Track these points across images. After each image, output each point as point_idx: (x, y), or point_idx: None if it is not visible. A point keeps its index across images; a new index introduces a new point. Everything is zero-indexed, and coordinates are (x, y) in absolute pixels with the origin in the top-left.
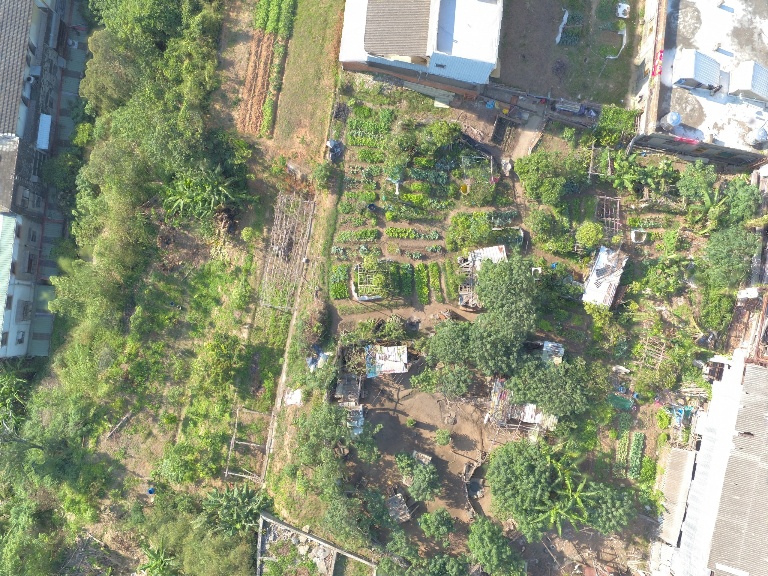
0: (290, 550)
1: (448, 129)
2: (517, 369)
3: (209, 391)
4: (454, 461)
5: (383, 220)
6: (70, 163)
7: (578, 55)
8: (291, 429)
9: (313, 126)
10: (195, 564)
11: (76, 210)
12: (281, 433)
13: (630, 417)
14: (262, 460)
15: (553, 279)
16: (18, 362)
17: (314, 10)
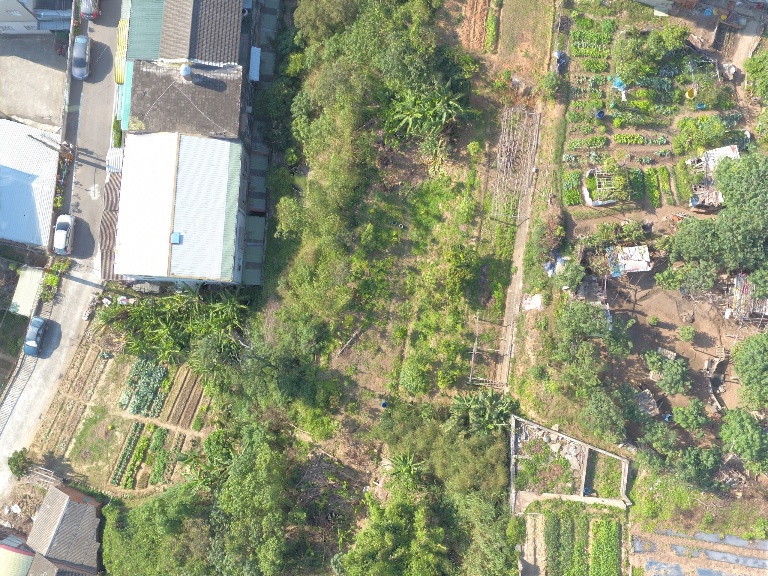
0: (543, 448)
1: (680, 32)
2: (761, 262)
3: (438, 305)
4: (694, 358)
5: (610, 127)
6: (286, 91)
7: None
8: (533, 333)
9: (535, 40)
10: (448, 466)
11: (287, 140)
12: (522, 338)
13: None
14: (495, 369)
15: None
16: (236, 290)
17: None
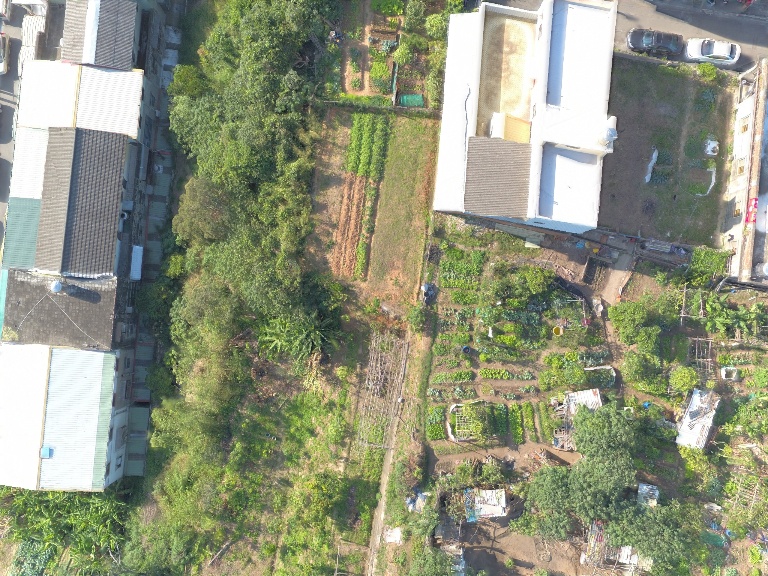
0: None
1: (543, 278)
2: (614, 514)
3: (306, 521)
4: None
5: (477, 361)
6: (164, 297)
7: (668, 193)
8: (391, 567)
9: (406, 268)
10: None
11: (169, 338)
12: (381, 569)
13: (721, 552)
14: None
15: (646, 419)
16: (116, 485)
17: (405, 151)
